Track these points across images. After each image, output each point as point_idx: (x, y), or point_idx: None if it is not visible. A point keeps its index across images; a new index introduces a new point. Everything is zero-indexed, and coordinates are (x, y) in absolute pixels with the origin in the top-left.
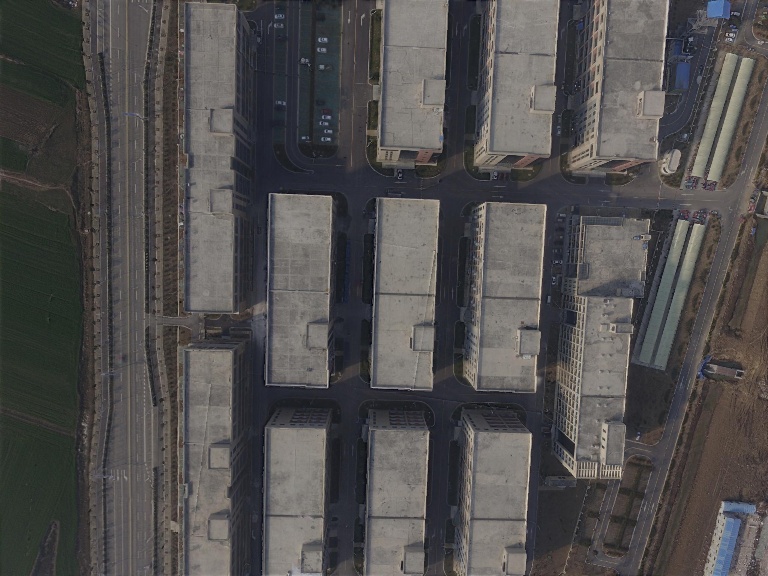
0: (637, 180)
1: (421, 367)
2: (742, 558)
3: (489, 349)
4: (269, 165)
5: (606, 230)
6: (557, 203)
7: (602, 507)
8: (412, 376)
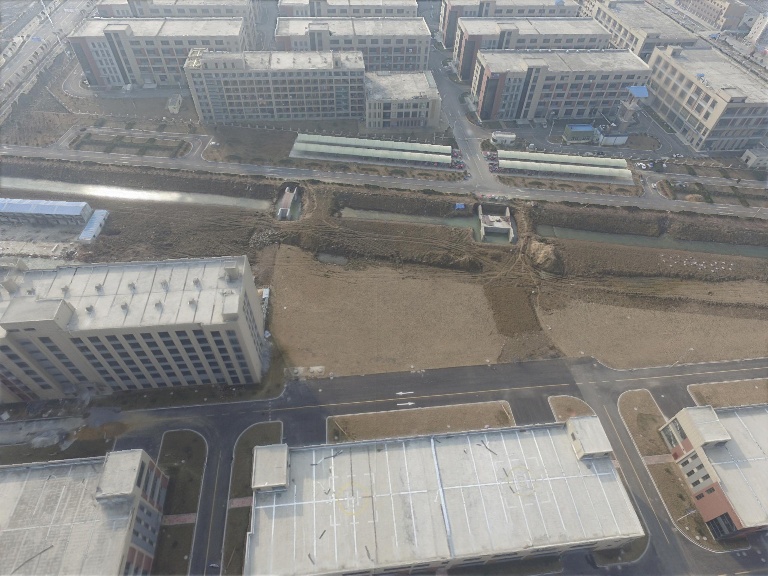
0: (477, 128)
1: (296, 4)
2: (7, 245)
3: None
4: None
5: (423, 81)
6: None
7: (137, 131)
8: (289, 2)
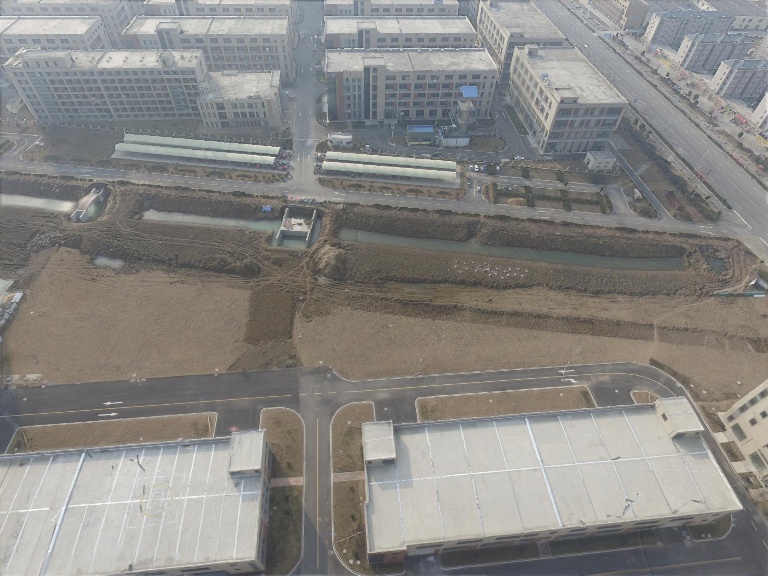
0: (322, 129)
1: None
2: None
3: (169, 21)
4: (320, 6)
5: None
6: (298, 93)
7: None
8: None
